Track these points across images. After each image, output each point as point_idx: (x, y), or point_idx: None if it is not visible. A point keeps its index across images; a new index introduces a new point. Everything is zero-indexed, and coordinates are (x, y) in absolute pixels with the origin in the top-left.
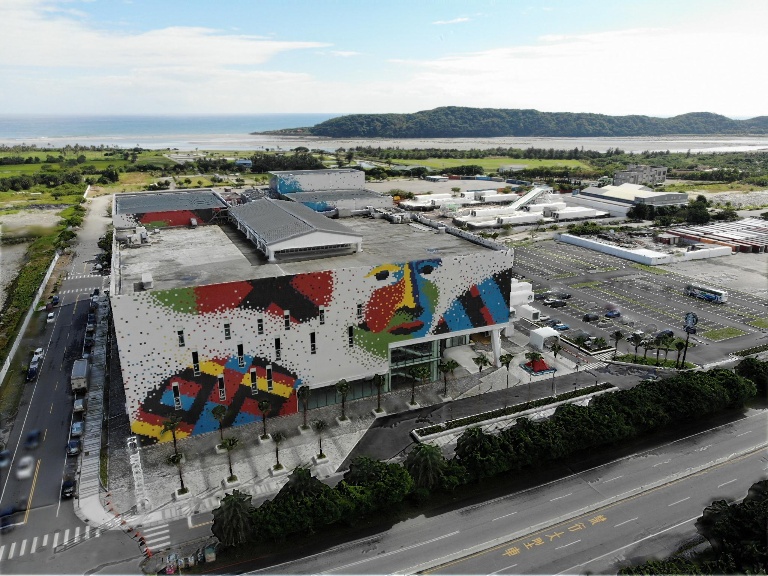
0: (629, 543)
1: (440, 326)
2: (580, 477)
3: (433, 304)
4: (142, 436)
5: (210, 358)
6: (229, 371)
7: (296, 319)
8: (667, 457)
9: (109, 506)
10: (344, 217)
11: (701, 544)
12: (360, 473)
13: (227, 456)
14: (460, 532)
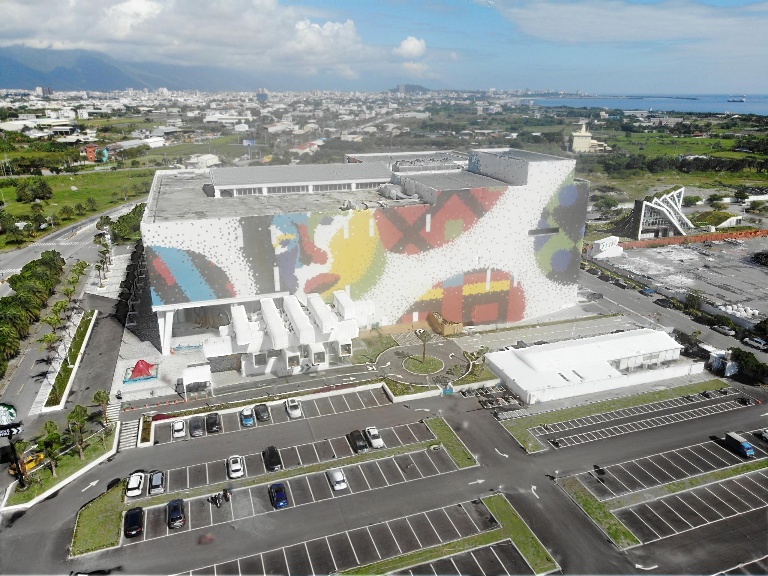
0: None
1: None
2: None
3: None
4: None
5: None
6: None
7: None
8: None
9: (121, 257)
10: (384, 196)
11: None
12: None
13: None
14: None
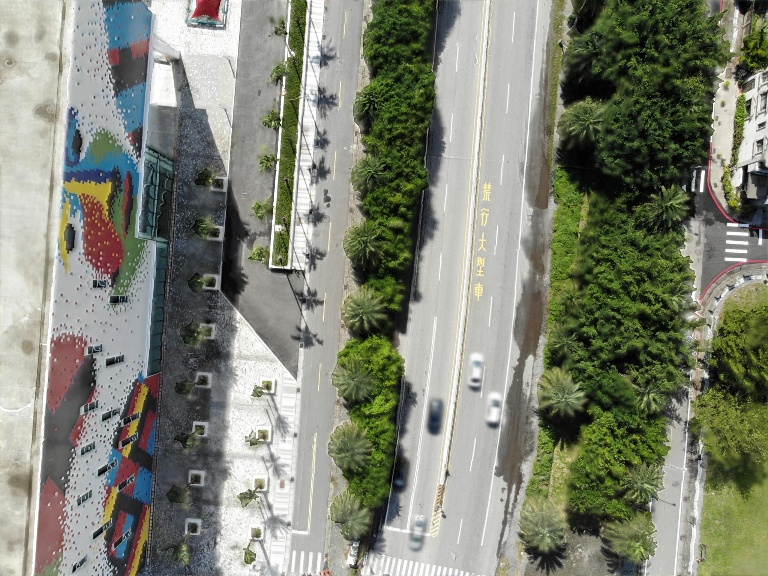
0: (522, 191)
1: (135, 143)
2: (432, 156)
3: (113, 147)
4: (139, 563)
5: (102, 511)
6: (116, 479)
7: (90, 393)
8: (452, 41)
9: None
10: None
11: (555, 135)
12: (365, 394)
13: (212, 477)
14: (438, 317)
